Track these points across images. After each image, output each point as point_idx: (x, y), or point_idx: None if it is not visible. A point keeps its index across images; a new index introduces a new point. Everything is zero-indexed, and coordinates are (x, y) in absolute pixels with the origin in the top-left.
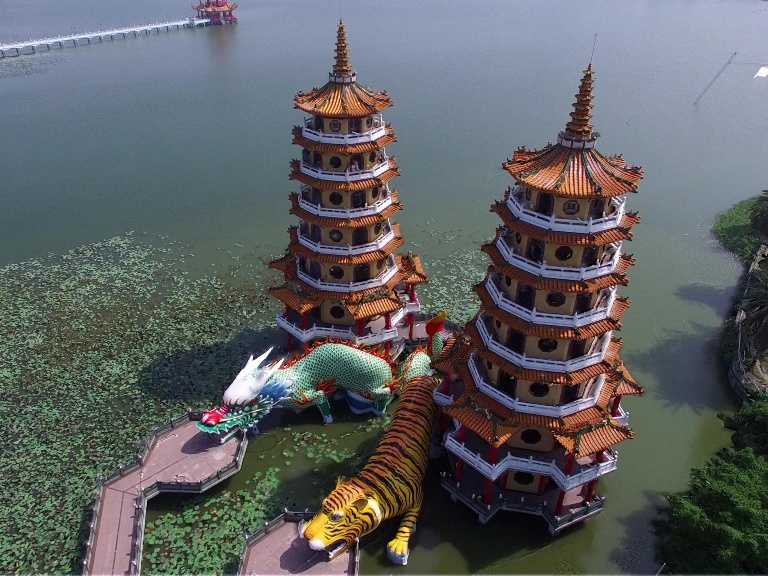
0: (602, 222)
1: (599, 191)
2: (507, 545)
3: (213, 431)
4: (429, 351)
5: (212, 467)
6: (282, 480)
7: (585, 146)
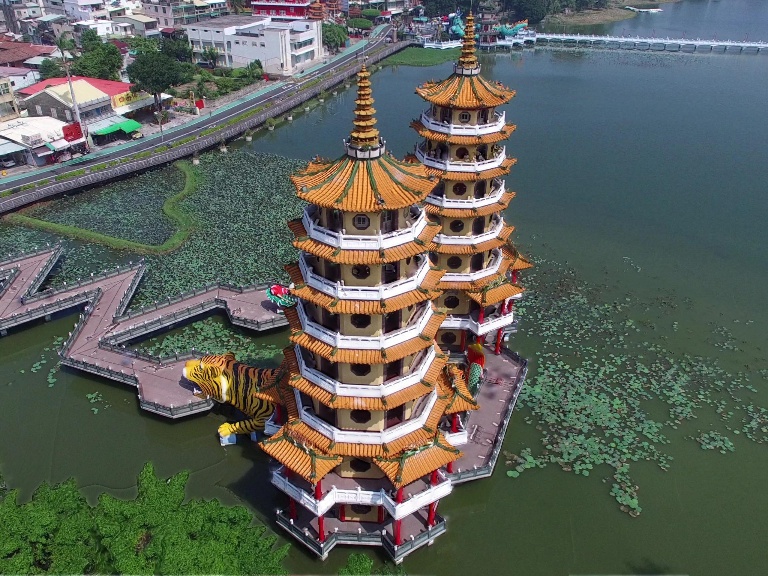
0: (324, 233)
1: (300, 190)
2: (270, 506)
3: (270, 297)
4: (467, 377)
5: (255, 318)
6: (274, 358)
7: (348, 152)
